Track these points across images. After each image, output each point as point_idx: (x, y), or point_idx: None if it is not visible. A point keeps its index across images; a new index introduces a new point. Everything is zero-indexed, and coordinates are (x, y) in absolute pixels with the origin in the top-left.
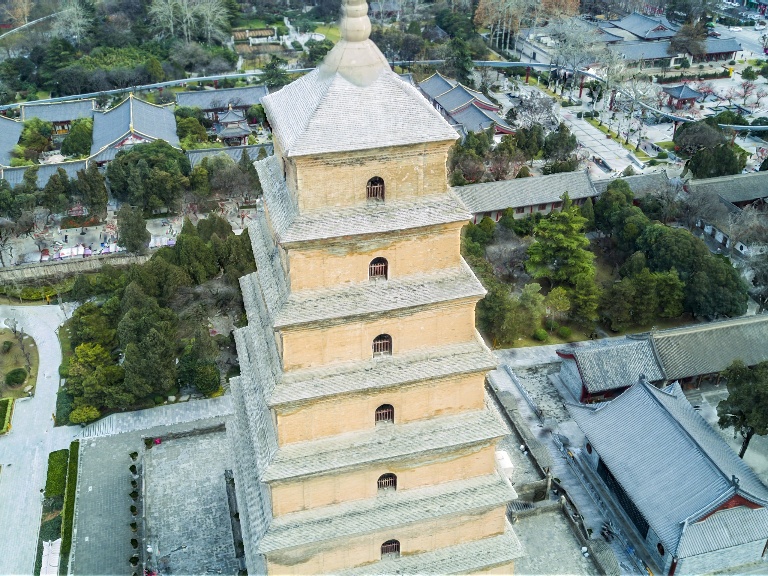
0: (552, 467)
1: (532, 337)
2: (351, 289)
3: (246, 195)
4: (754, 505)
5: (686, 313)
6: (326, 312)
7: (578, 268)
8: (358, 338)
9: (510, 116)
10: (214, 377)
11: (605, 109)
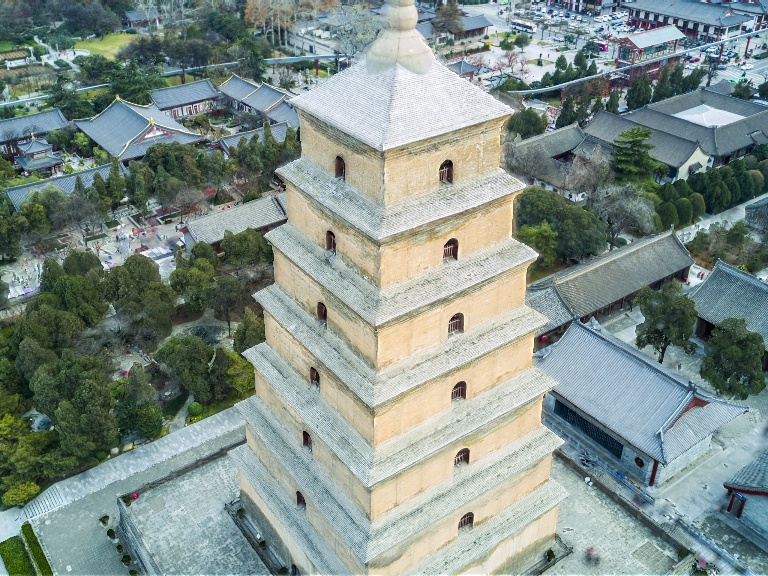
0: None
1: None
2: (430, 275)
3: (86, 226)
4: (704, 403)
5: (556, 260)
6: (416, 301)
7: None
8: (438, 322)
9: None
10: (158, 416)
11: None
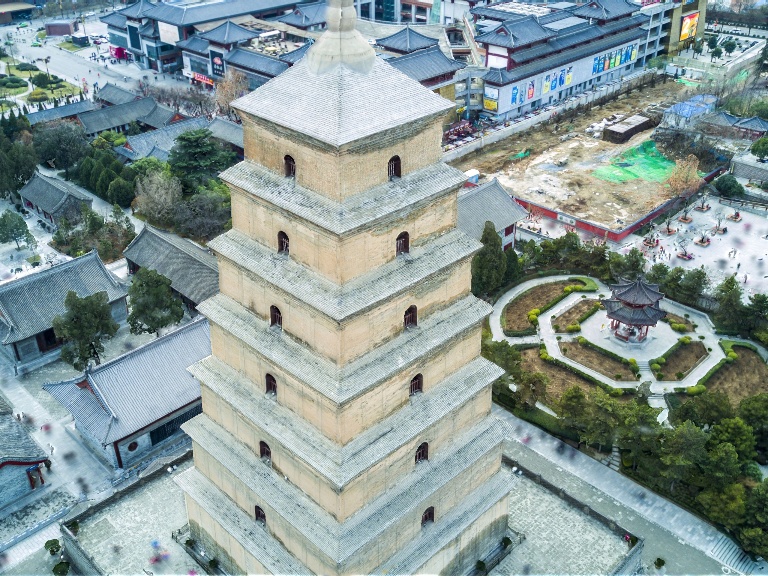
0: None
1: None
2: None
3: None
4: None
5: None
6: None
7: None
8: None
9: None
10: None
11: None
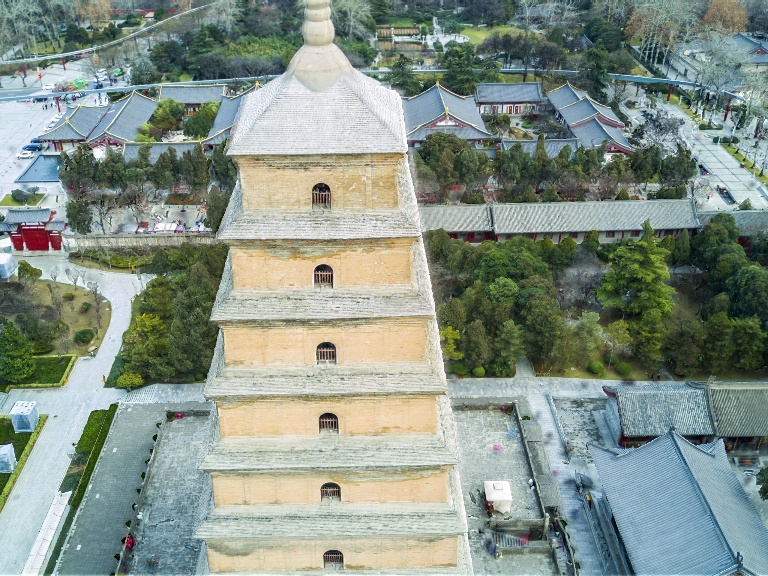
0: (564, 508)
1: (586, 369)
2: (294, 293)
3: None
4: None
5: None
6: (265, 312)
7: (653, 302)
8: (300, 343)
9: (636, 134)
10: None
11: (744, 136)
